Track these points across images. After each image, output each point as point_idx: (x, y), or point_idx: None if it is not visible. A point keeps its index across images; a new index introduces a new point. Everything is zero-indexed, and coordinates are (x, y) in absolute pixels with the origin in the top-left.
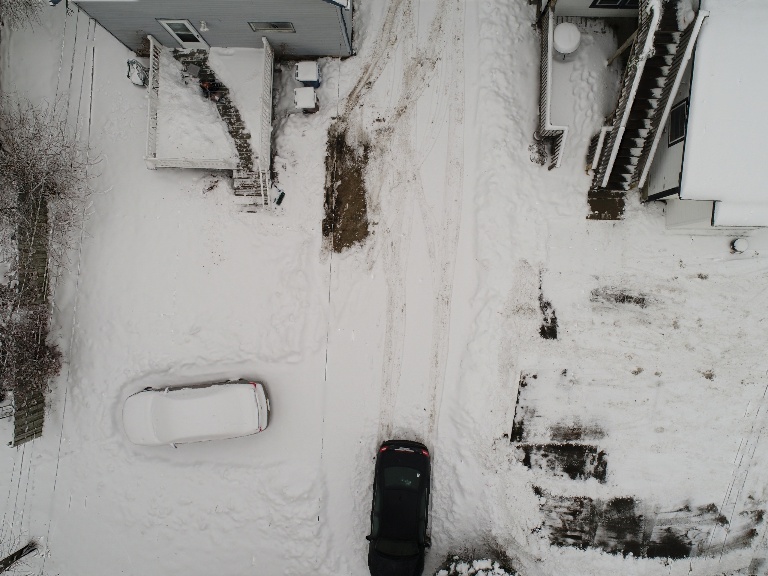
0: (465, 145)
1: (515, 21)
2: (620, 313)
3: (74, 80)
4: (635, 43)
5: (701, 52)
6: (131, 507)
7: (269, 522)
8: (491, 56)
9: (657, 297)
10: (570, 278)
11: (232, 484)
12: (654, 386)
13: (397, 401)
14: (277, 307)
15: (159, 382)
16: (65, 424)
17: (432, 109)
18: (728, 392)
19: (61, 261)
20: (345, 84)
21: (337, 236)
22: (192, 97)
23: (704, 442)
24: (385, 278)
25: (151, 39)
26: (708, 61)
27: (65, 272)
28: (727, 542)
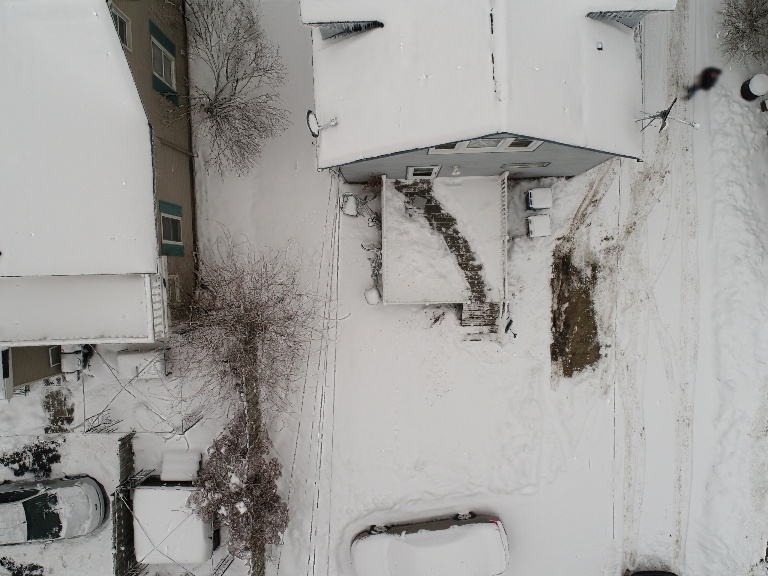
0: (699, 260)
1: (750, 130)
2: None
3: (276, 211)
4: None
5: None
6: None
7: None
8: (727, 168)
9: None
10: None
11: None
12: None
13: (640, 528)
14: (508, 437)
15: (383, 519)
16: (286, 568)
17: (663, 225)
18: None
19: (283, 406)
20: (571, 203)
21: (567, 360)
22: (420, 231)
23: None
24: (621, 402)
25: (385, 178)
26: None
27: None
28: None
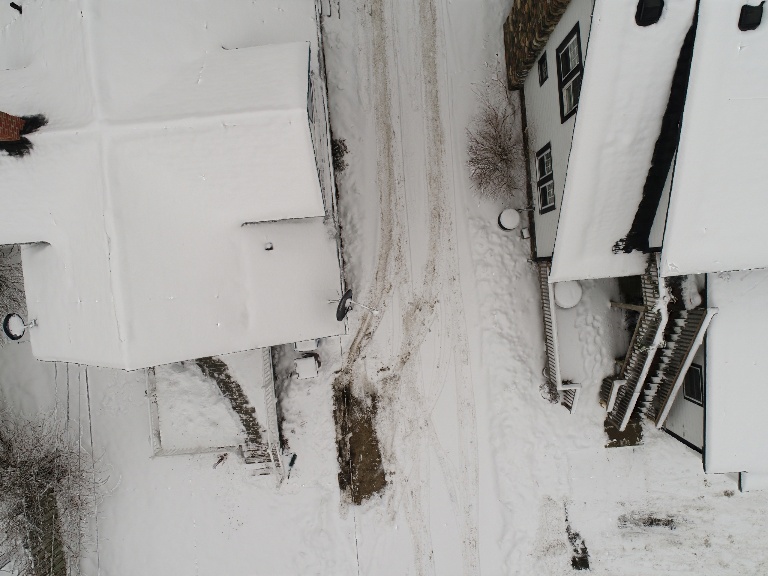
0: (474, 385)
1: (510, 259)
2: (650, 537)
3: None
4: (642, 320)
5: (713, 342)
6: None
7: None
8: (490, 298)
9: (685, 517)
10: (596, 507)
11: None
12: None
13: None
14: (303, 567)
15: None
16: None
17: (436, 353)
18: None
19: (77, 552)
20: (344, 338)
21: (355, 488)
22: (191, 380)
23: None
24: (409, 527)
25: None
26: (721, 350)
27: (81, 553)
28: None
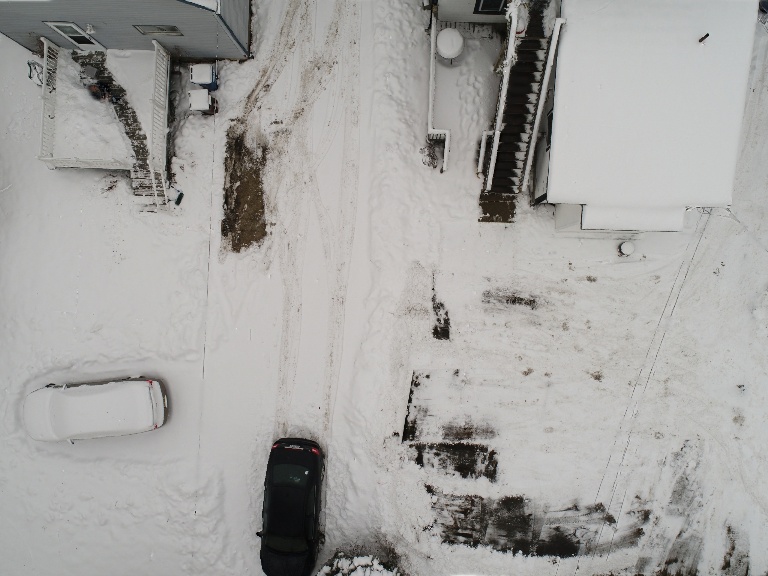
0: (361, 148)
1: (409, 26)
2: (511, 314)
3: None
4: (505, 49)
5: (561, 59)
6: (33, 502)
7: (167, 518)
8: (385, 60)
9: (547, 299)
10: (462, 279)
11: (132, 480)
12: (544, 387)
13: (293, 399)
14: (176, 306)
15: (62, 379)
16: None
17: (328, 112)
18: (616, 393)
19: None
20: (243, 87)
21: (236, 236)
22: (89, 98)
23: (592, 442)
24: (282, 278)
25: (44, 41)
26: (568, 67)
27: None
28: (614, 541)
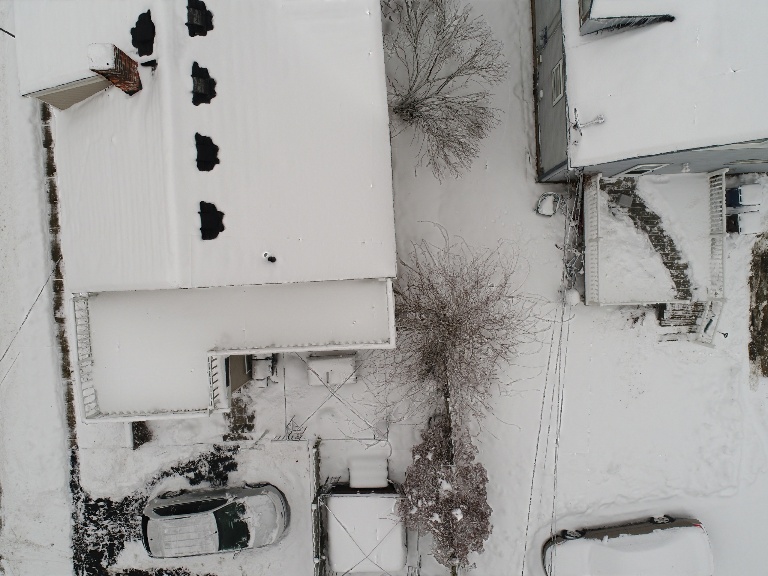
0: None
1: None
2: None
3: (465, 212)
4: None
5: None
6: None
7: None
8: None
9: None
10: None
11: None
12: None
13: None
14: (706, 439)
15: (574, 524)
16: (476, 575)
17: None
18: None
19: (480, 410)
20: None
21: (765, 359)
22: (627, 230)
23: None
24: None
25: None
26: None
27: (469, 416)
28: None
